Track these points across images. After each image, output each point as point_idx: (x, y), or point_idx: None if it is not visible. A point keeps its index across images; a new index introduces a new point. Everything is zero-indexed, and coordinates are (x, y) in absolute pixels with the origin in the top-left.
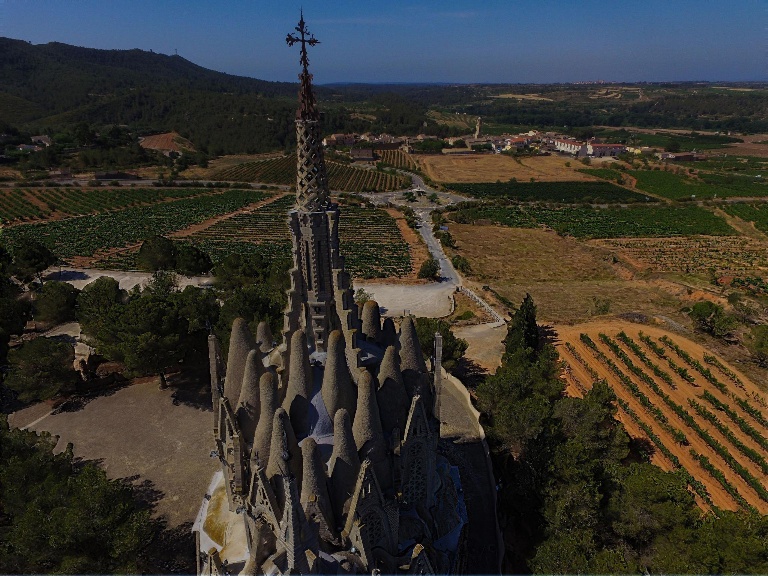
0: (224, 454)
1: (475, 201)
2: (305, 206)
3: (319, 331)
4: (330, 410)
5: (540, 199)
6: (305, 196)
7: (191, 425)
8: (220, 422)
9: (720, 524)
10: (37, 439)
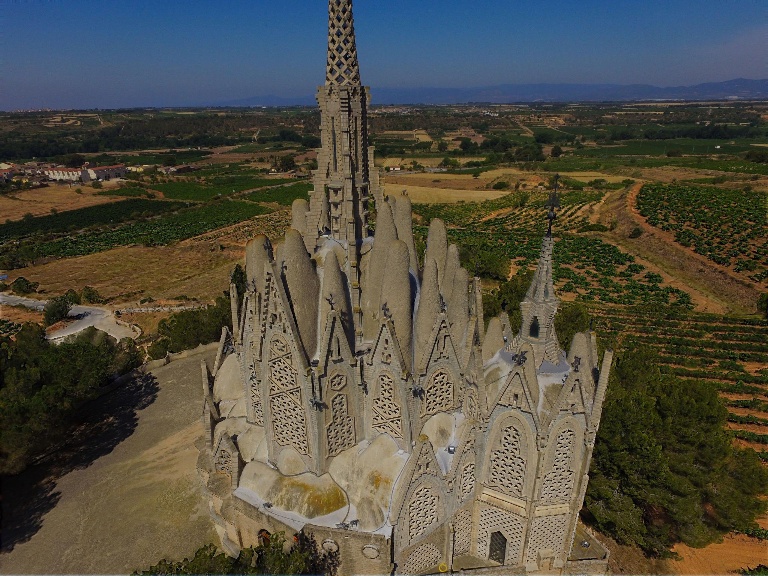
0: (322, 395)
1: (3, 245)
2: (351, 80)
3: (367, 213)
4: (416, 270)
5: (84, 226)
6: (352, 69)
7: (18, 574)
8: (327, 346)
9: (505, 290)
10: None
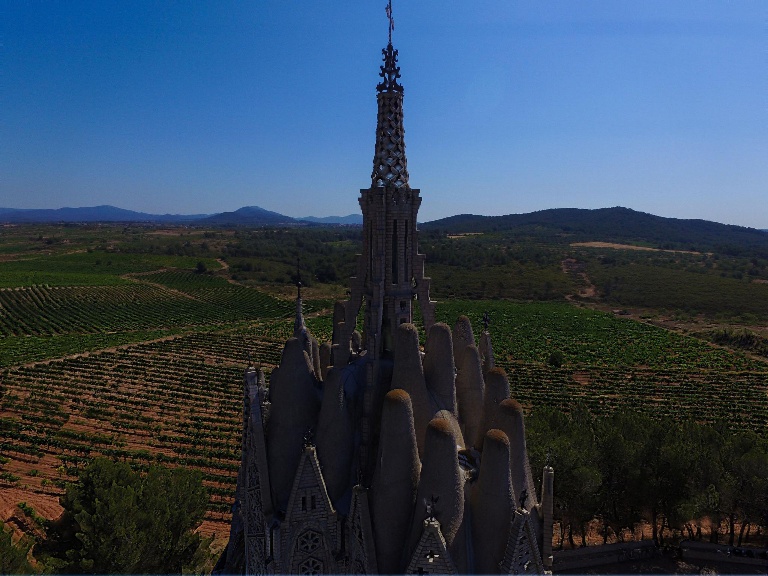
0: None
1: None
2: None
3: None
4: None
5: None
6: None
7: None
8: None
9: None
10: (669, 459)
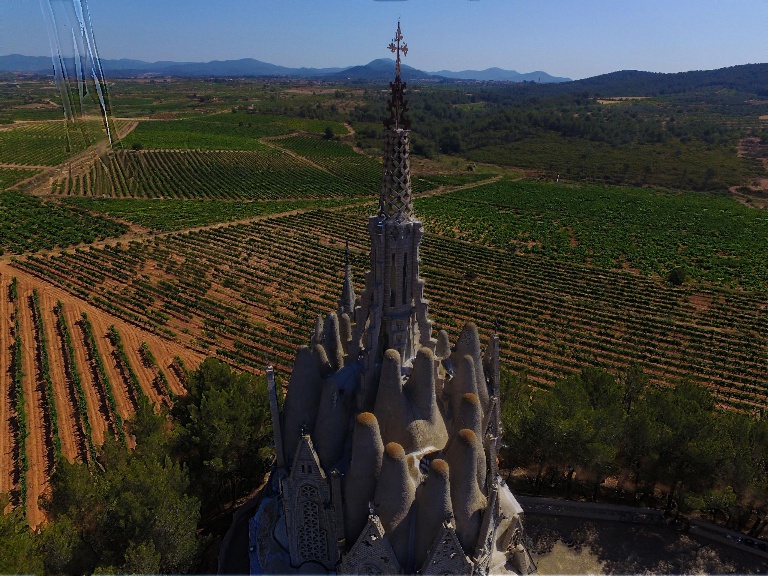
0: None
1: None
2: None
3: None
4: None
5: None
6: None
7: None
8: None
9: None
10: None
